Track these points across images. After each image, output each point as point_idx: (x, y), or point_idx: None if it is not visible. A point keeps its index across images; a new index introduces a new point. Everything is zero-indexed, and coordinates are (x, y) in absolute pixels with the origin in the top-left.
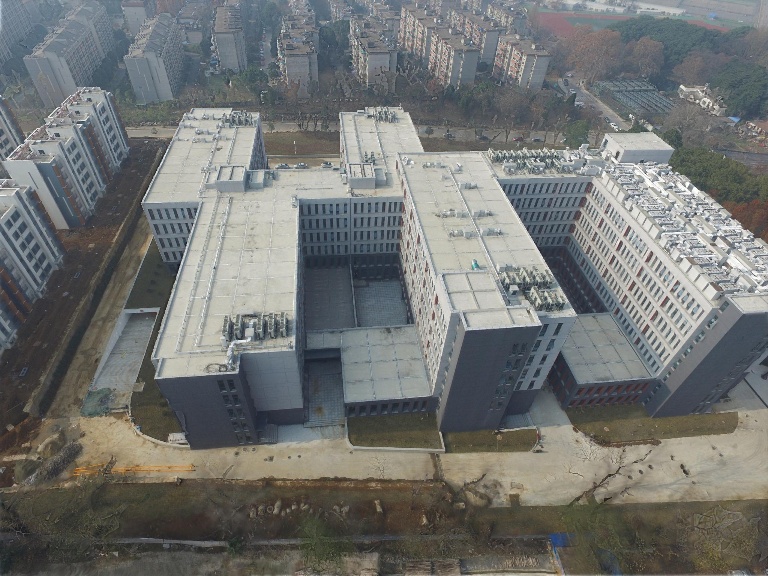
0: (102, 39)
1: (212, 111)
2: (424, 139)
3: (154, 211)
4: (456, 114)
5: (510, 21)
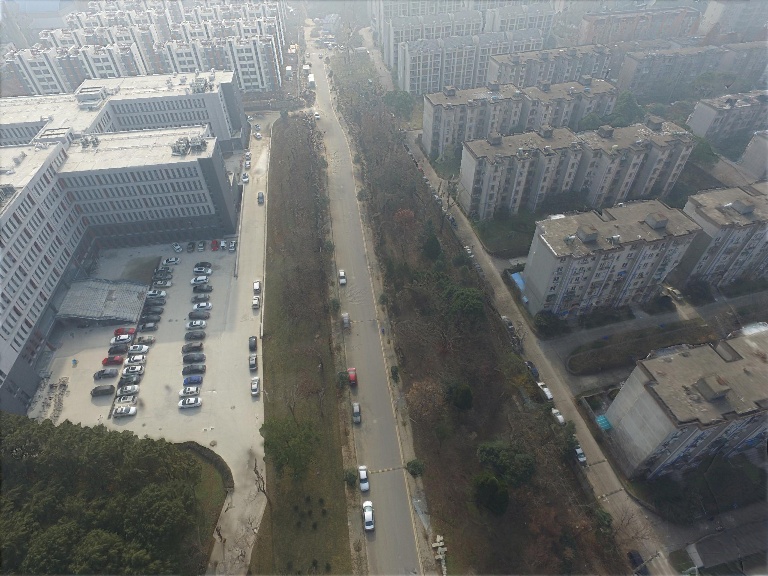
0: None
1: (228, 77)
2: (309, 244)
3: None
4: None
5: None
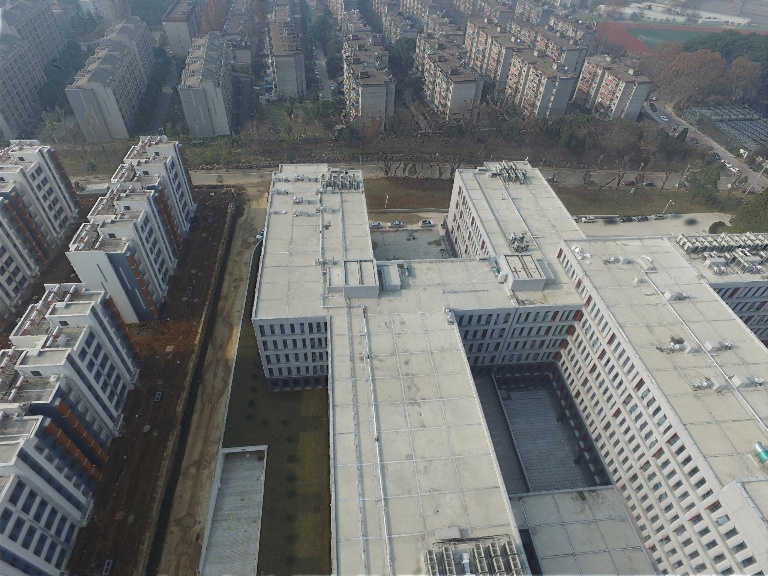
0: (144, 59)
1: (304, 168)
2: None
3: (266, 326)
4: (552, 152)
5: (579, 35)
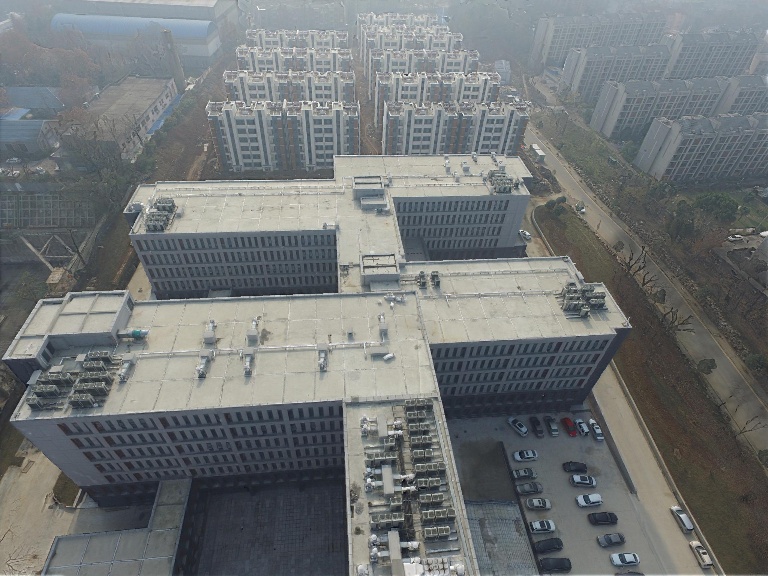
0: (740, 110)
1: (520, 167)
2: (729, 447)
3: None
4: None
5: None
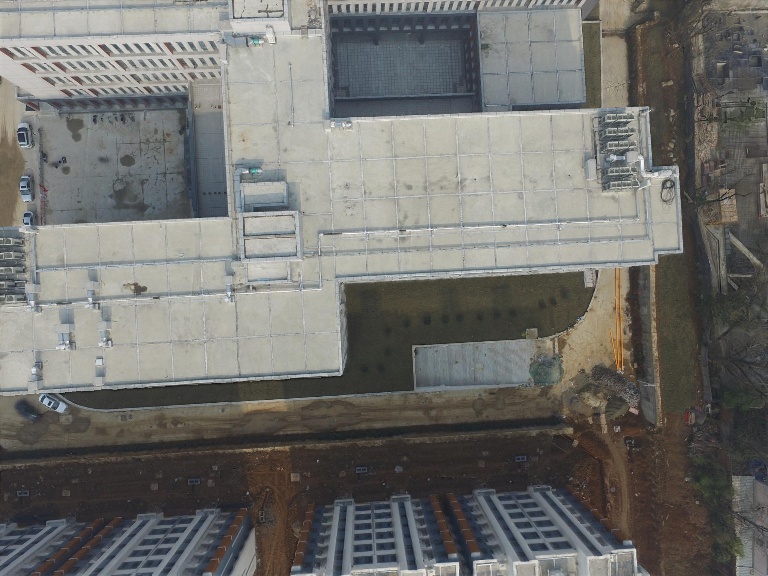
0: None
1: None
2: None
3: None
4: None
5: None
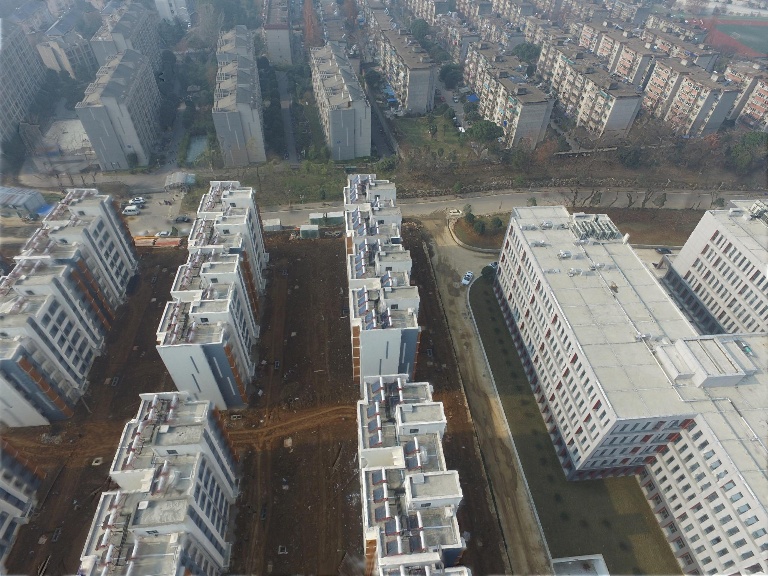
0: None
1: (541, 212)
2: None
3: (621, 425)
4: (721, 172)
5: None
